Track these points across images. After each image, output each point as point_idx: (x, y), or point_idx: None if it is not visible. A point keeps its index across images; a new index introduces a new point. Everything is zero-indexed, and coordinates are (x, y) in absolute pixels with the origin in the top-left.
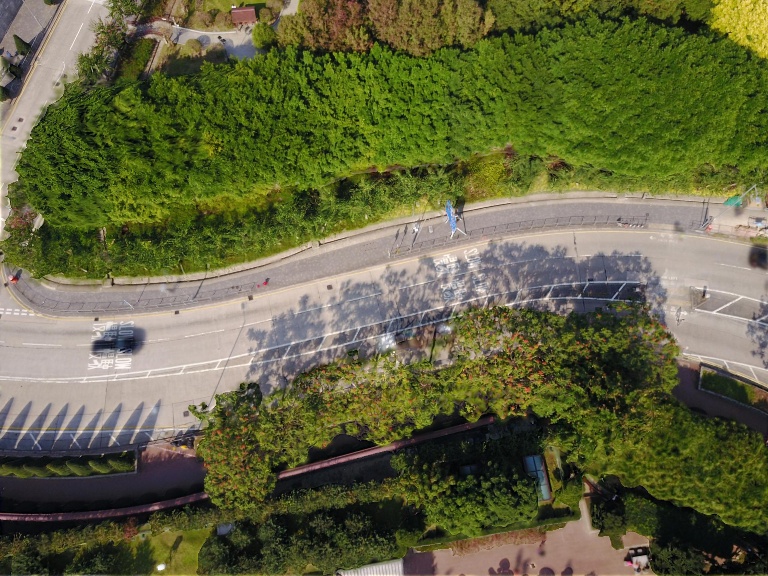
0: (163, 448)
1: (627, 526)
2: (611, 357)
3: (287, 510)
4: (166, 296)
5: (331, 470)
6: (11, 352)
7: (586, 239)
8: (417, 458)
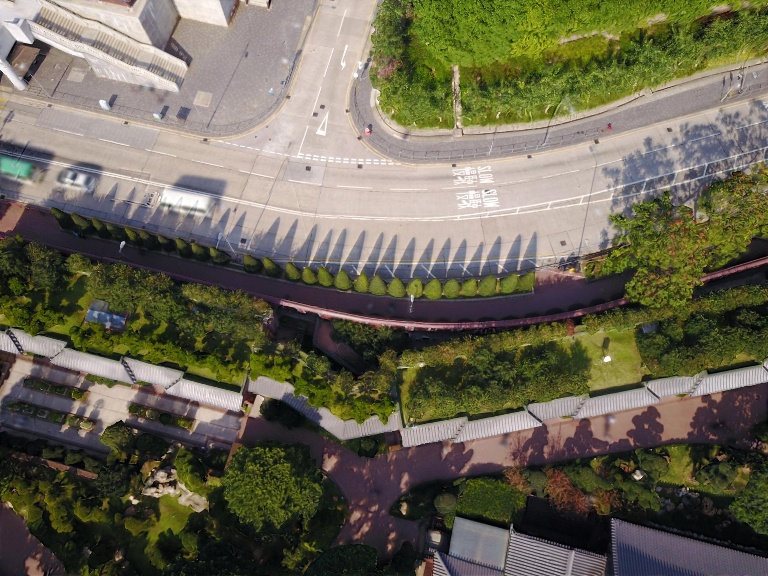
0: (554, 271)
1: None
2: None
3: (710, 308)
4: (516, 142)
5: (707, 288)
6: (382, 196)
7: None
8: None
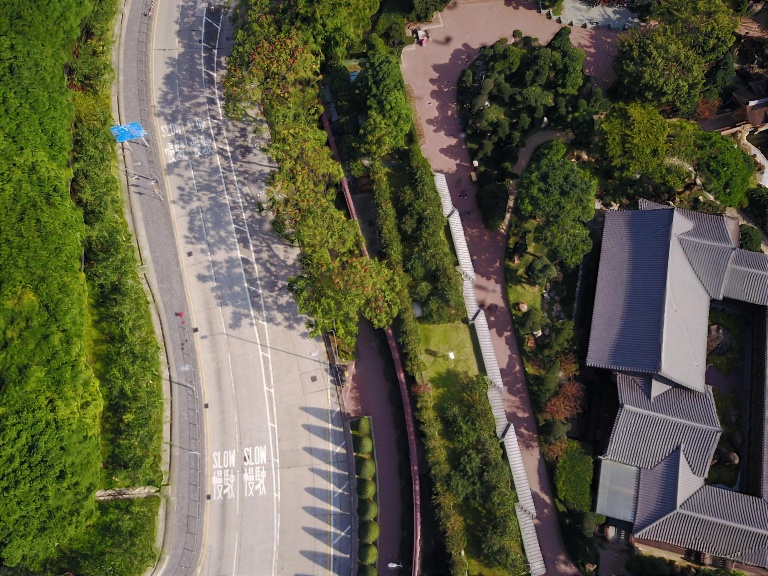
0: (347, 393)
1: (399, 22)
2: (273, 1)
3: (399, 255)
4: (187, 420)
5: None
6: None
7: (161, 41)
8: (354, 143)
